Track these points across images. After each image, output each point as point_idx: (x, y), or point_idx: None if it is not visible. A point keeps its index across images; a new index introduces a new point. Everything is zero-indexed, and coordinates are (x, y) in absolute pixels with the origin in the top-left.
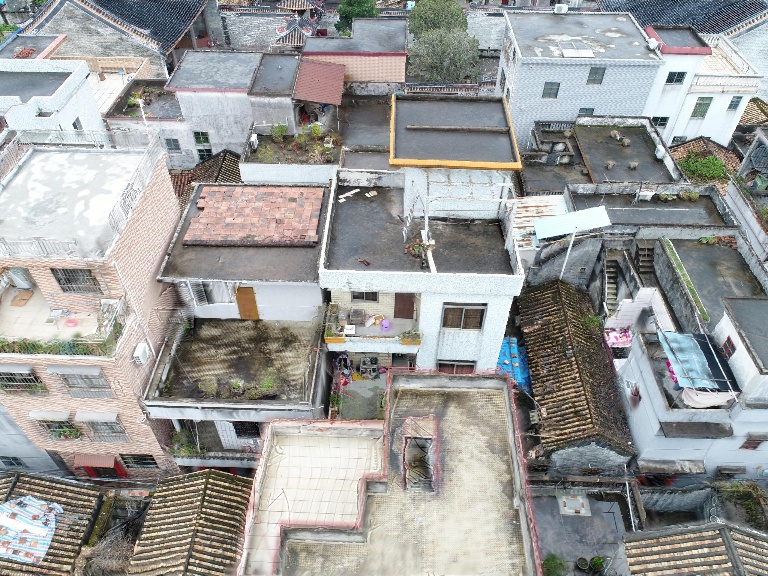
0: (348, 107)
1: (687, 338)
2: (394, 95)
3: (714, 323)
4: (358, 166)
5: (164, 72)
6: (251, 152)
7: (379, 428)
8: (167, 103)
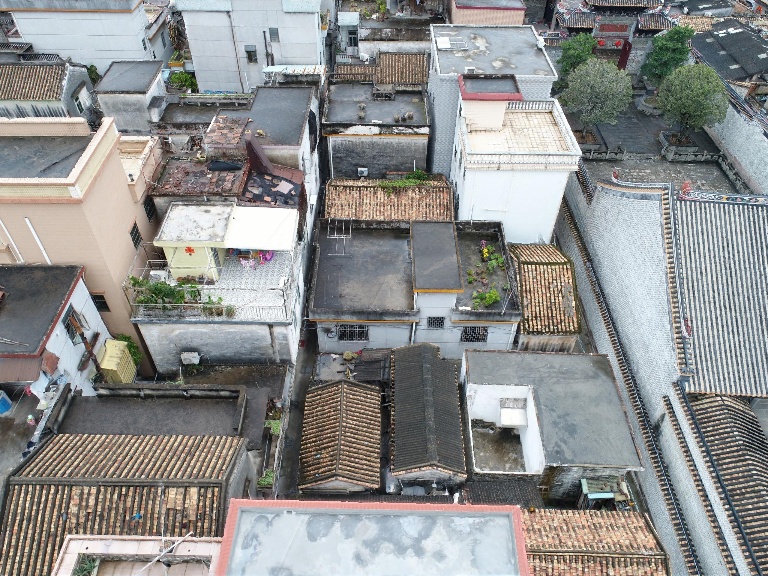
0: (428, 23)
1: (163, 78)
2: None
3: (187, 110)
4: None
5: None
6: (366, 1)
7: (149, 16)
8: None
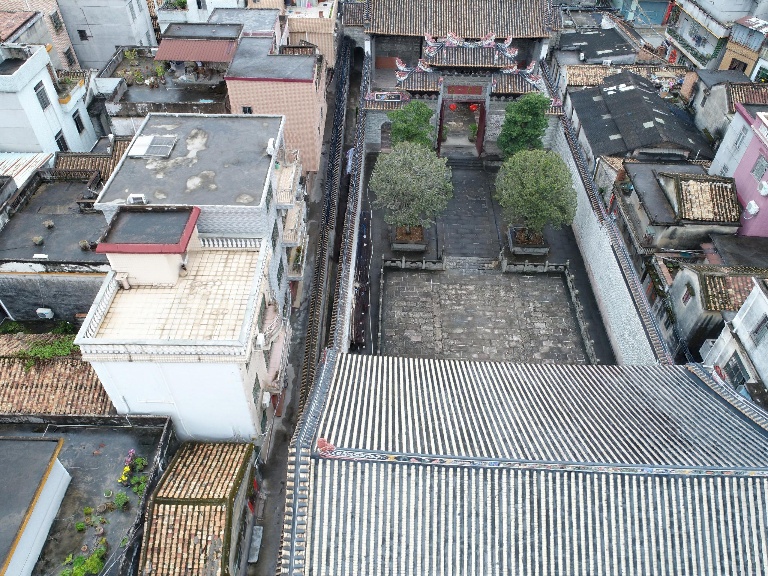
0: (212, 90)
1: None
2: None
3: None
4: None
5: (365, 44)
6: None
7: None
8: None
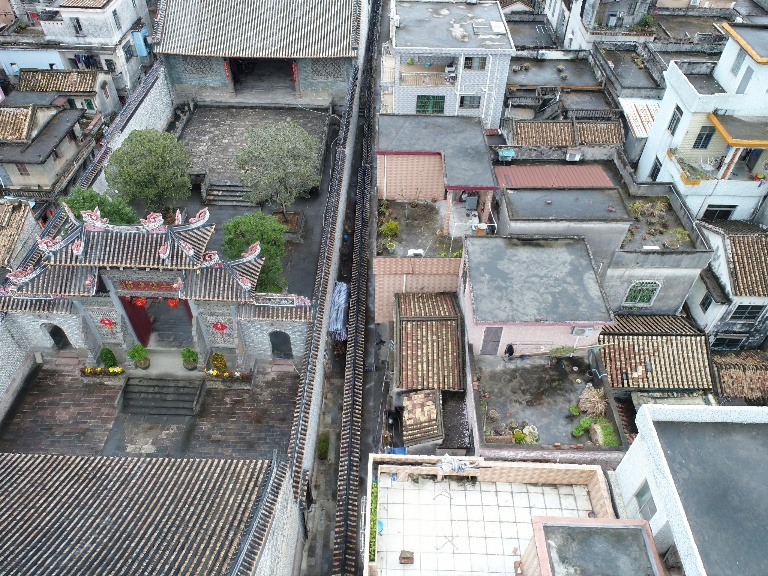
0: None
1: None
2: (764, 57)
3: None
4: (750, 136)
5: None
6: None
7: None
8: (515, 399)
